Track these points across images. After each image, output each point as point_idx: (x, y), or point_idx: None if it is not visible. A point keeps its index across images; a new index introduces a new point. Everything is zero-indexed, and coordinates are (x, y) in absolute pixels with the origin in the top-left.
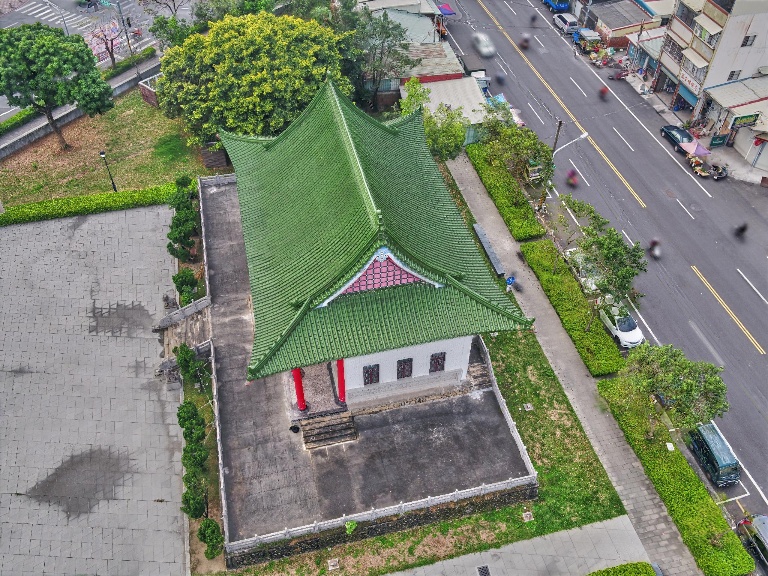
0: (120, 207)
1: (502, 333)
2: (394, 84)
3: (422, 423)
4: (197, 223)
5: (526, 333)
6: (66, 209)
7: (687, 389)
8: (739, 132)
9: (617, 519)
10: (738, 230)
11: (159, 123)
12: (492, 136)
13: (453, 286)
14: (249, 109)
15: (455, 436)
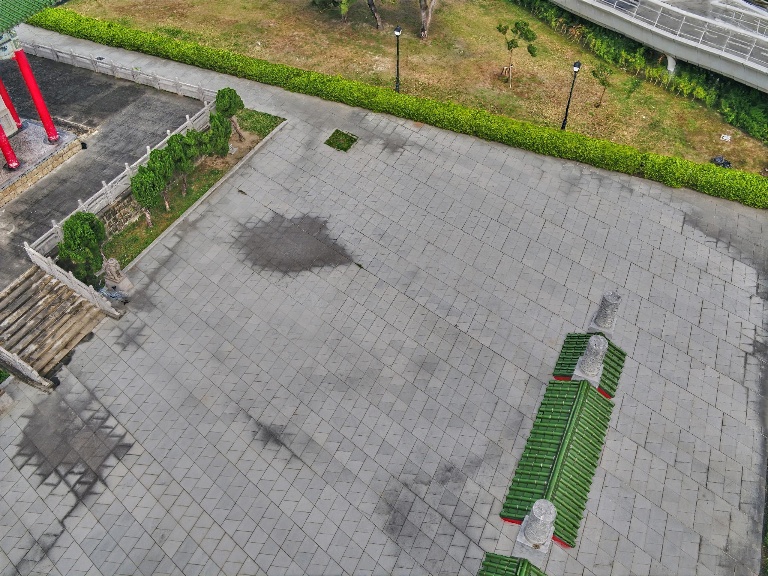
0: None
1: None
2: None
3: None
4: None
5: None
6: None
7: None
8: None
9: None
10: None
11: None
12: None
13: None
14: None
15: None
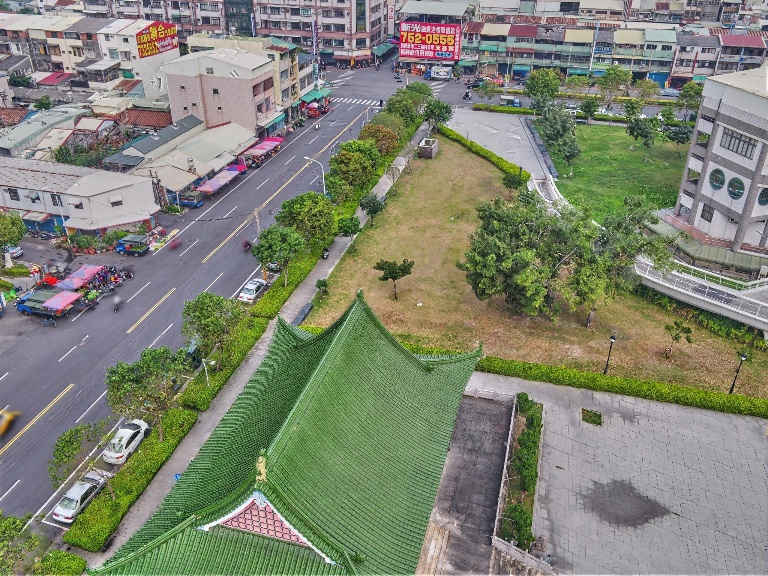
0: None
1: None
2: None
3: None
4: None
5: None
6: None
7: None
8: None
9: None
10: None
11: None
12: None
13: None
14: None
15: None
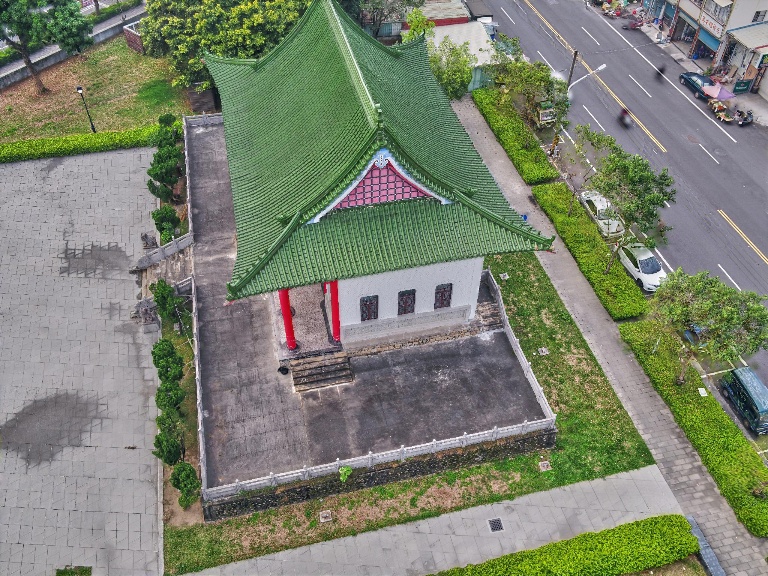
0: (99, 149)
1: (513, 276)
2: (395, 28)
3: (426, 365)
4: (182, 165)
5: (539, 276)
6: (40, 150)
7: (727, 317)
8: (765, 76)
9: (645, 469)
10: (767, 174)
11: (144, 68)
12: (501, 74)
13: (462, 203)
14: (238, 43)
15: (463, 378)
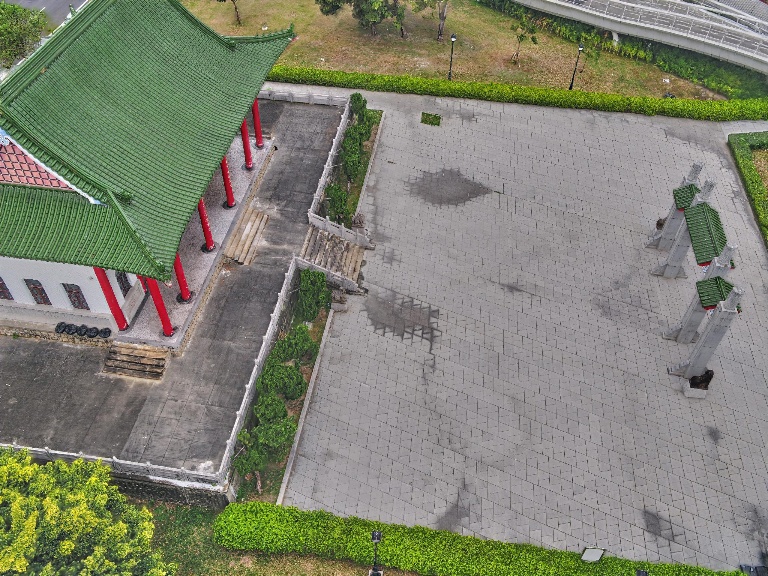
0: None
1: None
2: None
3: None
4: None
5: None
6: (470, 542)
7: None
8: None
9: None
10: None
11: None
12: None
13: None
14: None
15: None
